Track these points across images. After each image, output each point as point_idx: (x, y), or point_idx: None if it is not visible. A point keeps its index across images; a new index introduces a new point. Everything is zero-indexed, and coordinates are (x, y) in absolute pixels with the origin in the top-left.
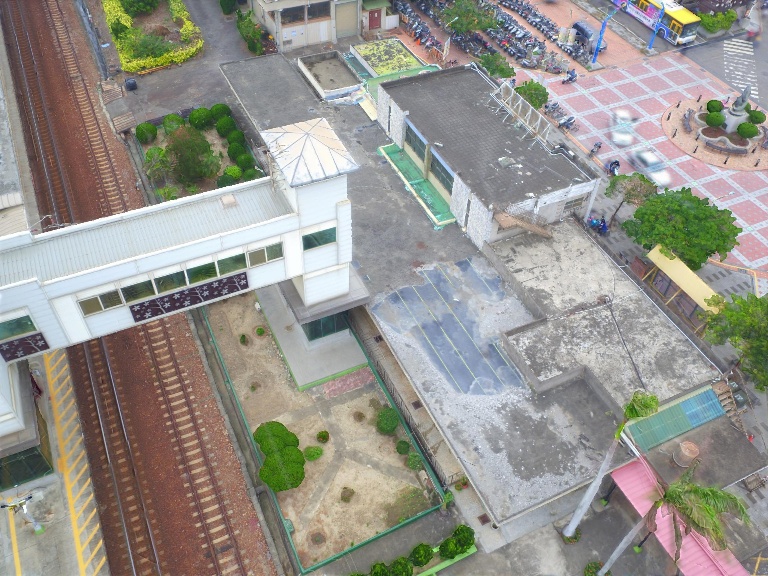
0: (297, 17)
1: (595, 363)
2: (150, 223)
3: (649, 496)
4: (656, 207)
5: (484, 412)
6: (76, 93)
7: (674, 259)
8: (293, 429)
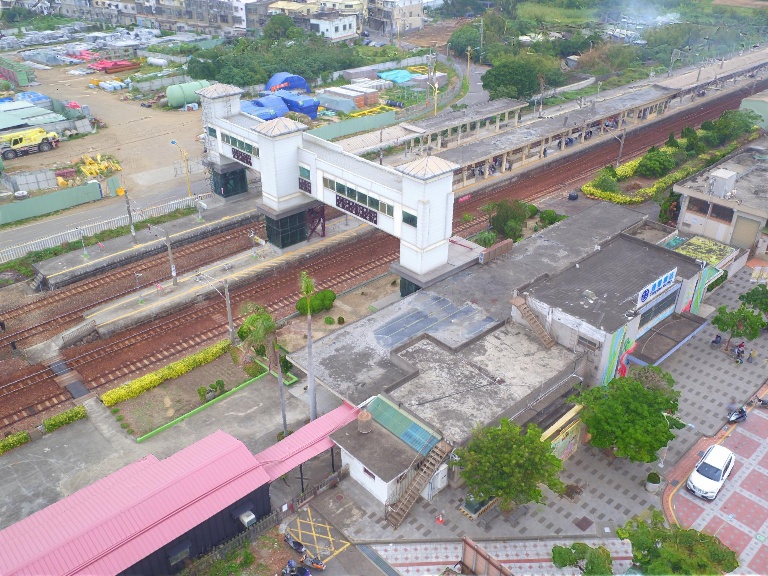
0: (703, 210)
1: (429, 380)
2: (371, 169)
3: (333, 422)
4: (620, 381)
5: (363, 342)
6: (549, 189)
7: (576, 410)
8: (343, 312)
